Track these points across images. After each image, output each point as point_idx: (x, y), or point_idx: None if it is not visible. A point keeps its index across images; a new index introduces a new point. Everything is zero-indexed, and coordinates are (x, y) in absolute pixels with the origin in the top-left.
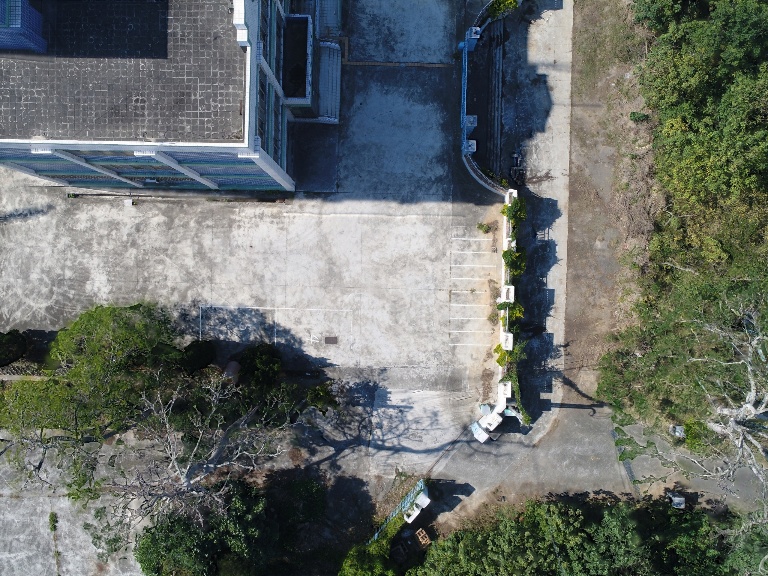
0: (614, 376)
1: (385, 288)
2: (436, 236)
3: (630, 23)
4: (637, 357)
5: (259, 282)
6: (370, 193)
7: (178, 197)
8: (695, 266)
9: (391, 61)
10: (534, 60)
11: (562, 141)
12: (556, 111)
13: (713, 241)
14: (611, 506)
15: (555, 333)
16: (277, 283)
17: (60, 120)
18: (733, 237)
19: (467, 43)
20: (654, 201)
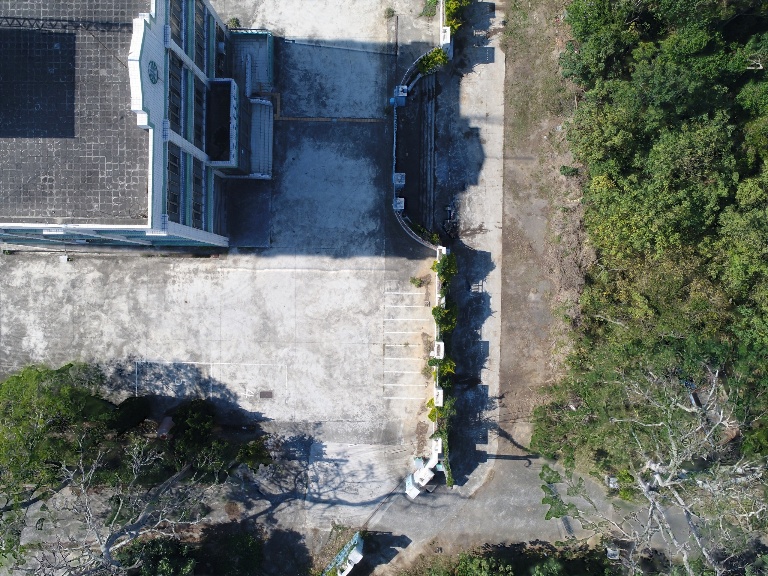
0: (549, 427)
1: (319, 342)
2: (369, 290)
3: (561, 76)
4: (571, 409)
5: (194, 337)
6: (303, 248)
7: (113, 253)
8: (625, 320)
9: (323, 116)
10: (466, 113)
11: (495, 194)
12: (489, 164)
13: (639, 298)
14: (547, 556)
15: (490, 385)
16: (212, 338)
17: None
18: (659, 293)
19: (395, 101)
20: (586, 254)
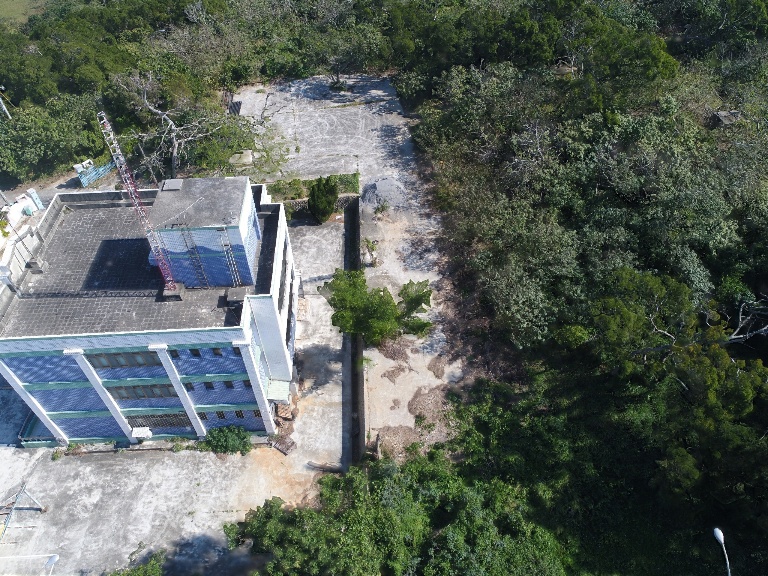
0: None
1: None
2: None
3: None
4: None
5: None
6: None
7: None
8: None
9: (8, 390)
10: None
11: None
12: None
13: None
14: None
15: None
16: None
17: None
18: None
19: None
20: None
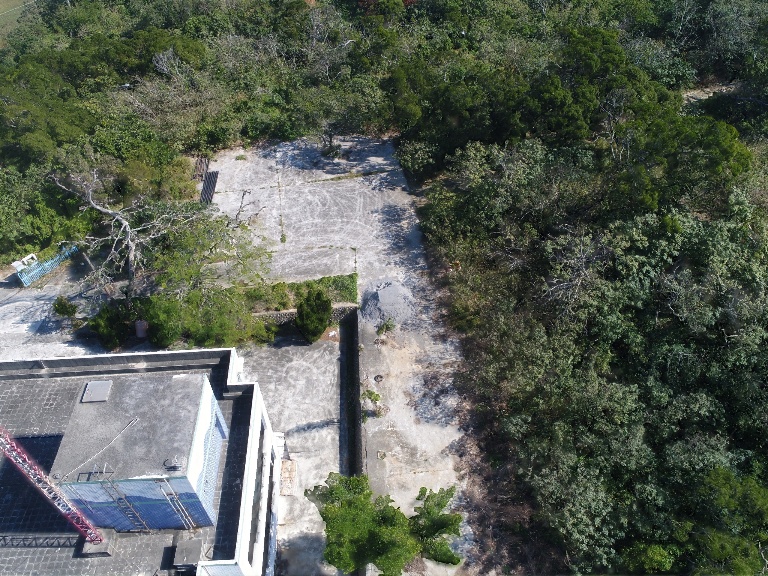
0: None
1: None
2: None
3: None
4: None
5: None
6: None
7: None
8: None
9: None
10: None
11: None
12: None
13: None
14: None
15: None
16: None
17: None
18: None
19: None
20: None
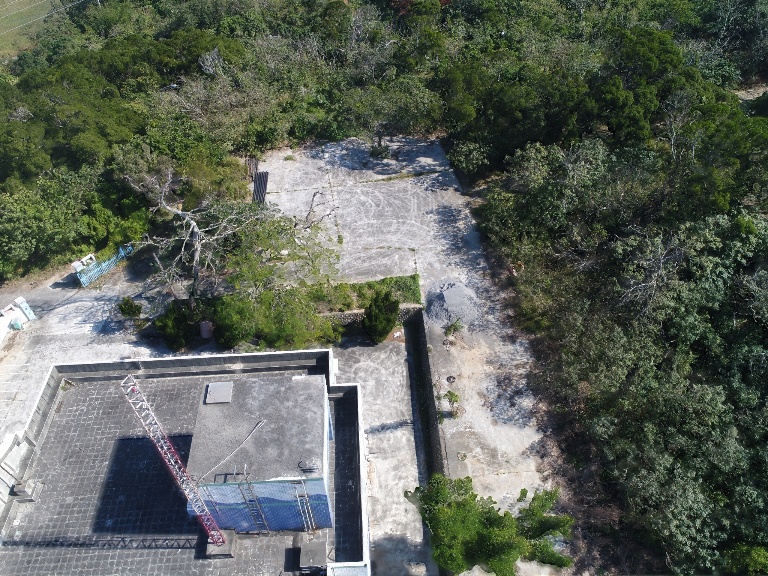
0: None
1: None
2: None
3: None
4: None
5: None
6: None
7: None
8: None
9: None
10: None
11: None
12: None
13: None
14: None
15: None
16: None
17: None
18: None
19: None
20: None
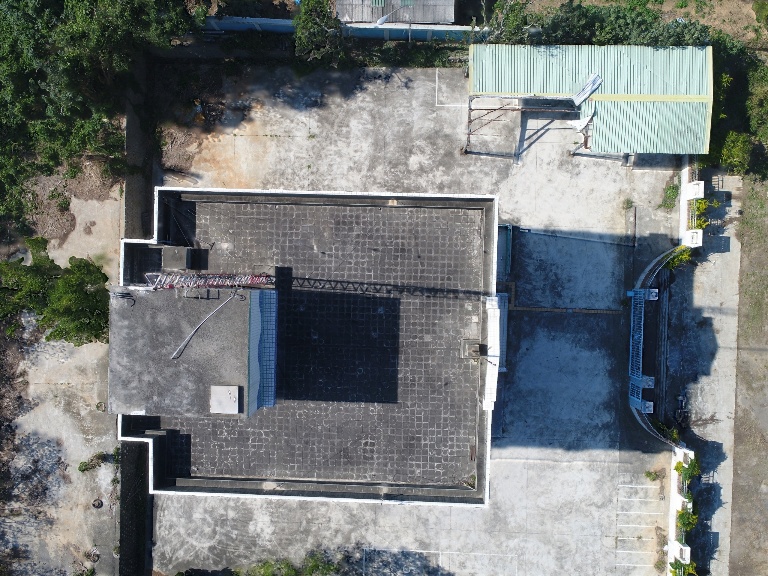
0: None
1: (551, 534)
2: (603, 483)
3: None
4: None
5: (423, 526)
6: (536, 439)
7: None
8: None
9: (558, 307)
10: (700, 303)
11: (728, 384)
12: (722, 354)
13: None
14: None
15: (719, 575)
16: (441, 527)
17: (288, 461)
18: None
19: (643, 302)
20: None
